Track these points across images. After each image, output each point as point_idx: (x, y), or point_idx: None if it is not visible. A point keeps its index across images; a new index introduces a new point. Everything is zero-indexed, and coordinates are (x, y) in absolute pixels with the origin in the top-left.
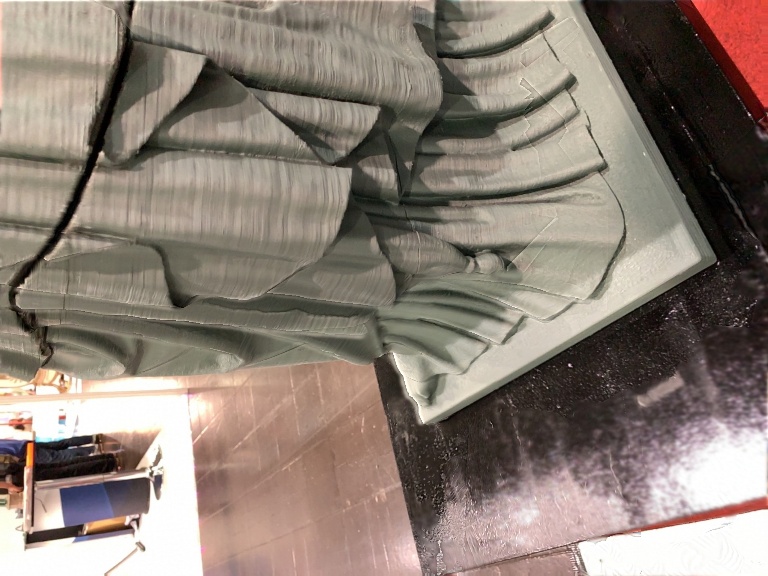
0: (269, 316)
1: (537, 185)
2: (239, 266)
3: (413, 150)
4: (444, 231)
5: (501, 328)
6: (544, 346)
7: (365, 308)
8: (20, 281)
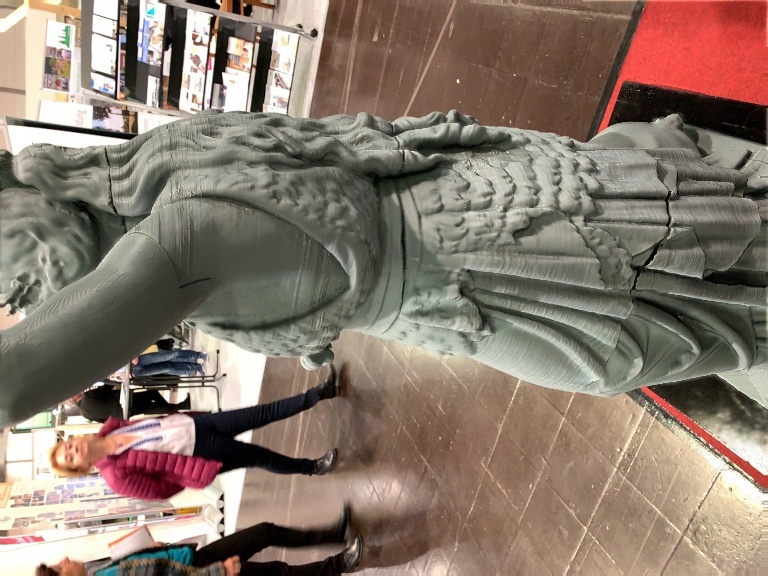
0: (730, 289)
1: None
2: (725, 245)
3: None
4: None
5: None
6: None
7: None
8: (651, 259)
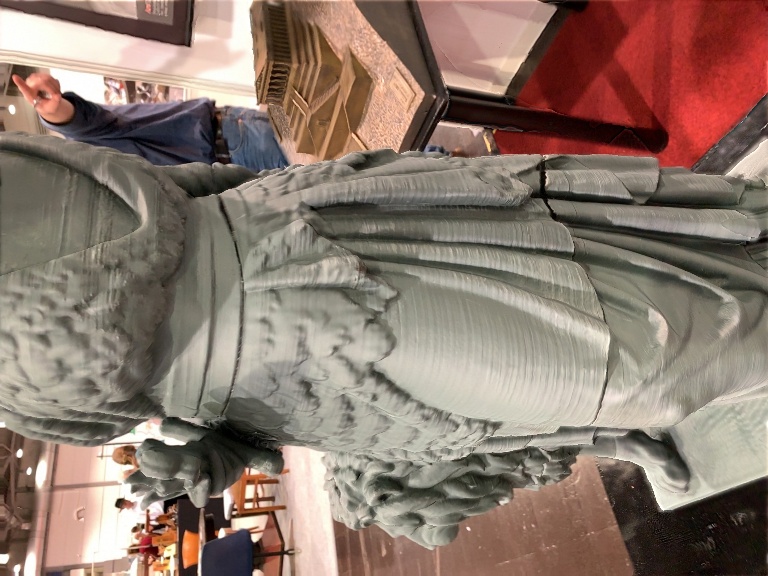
0: None
1: None
2: None
3: None
4: None
5: None
6: None
7: None
8: (544, 178)
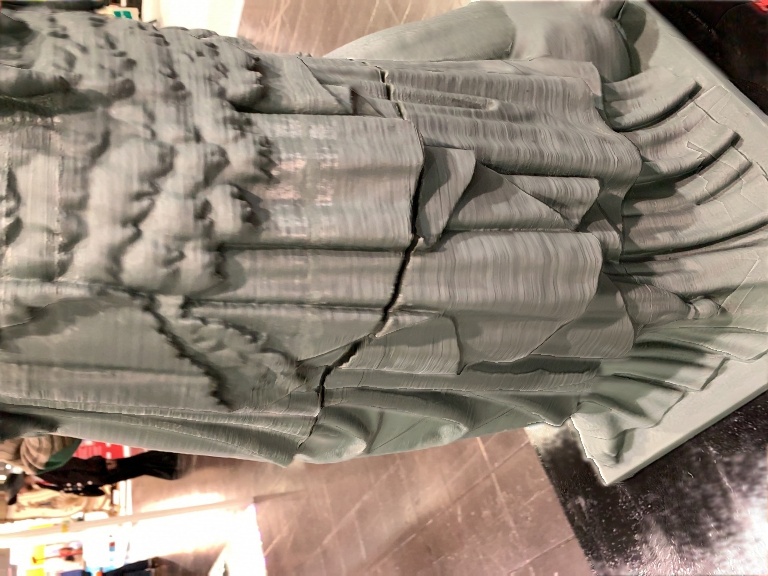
0: (518, 378)
1: (731, 233)
2: (512, 330)
3: (620, 214)
4: (662, 282)
5: (701, 374)
6: (750, 386)
7: (594, 363)
8: (345, 360)
